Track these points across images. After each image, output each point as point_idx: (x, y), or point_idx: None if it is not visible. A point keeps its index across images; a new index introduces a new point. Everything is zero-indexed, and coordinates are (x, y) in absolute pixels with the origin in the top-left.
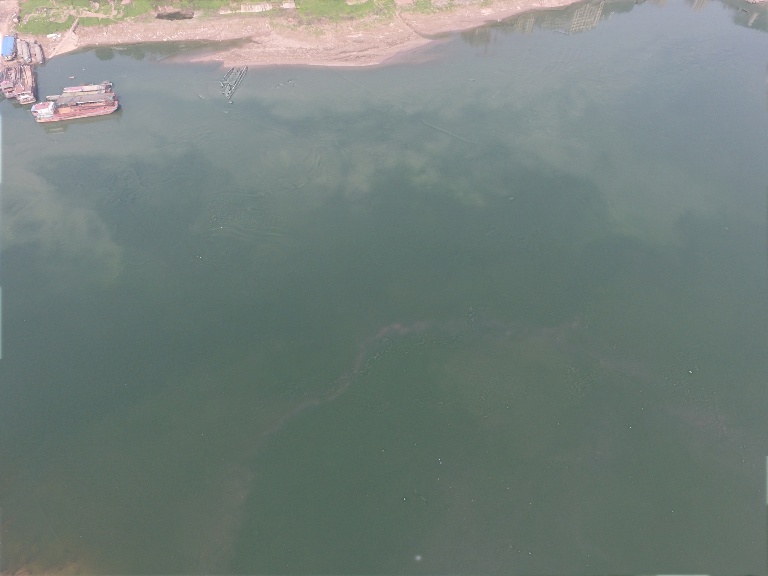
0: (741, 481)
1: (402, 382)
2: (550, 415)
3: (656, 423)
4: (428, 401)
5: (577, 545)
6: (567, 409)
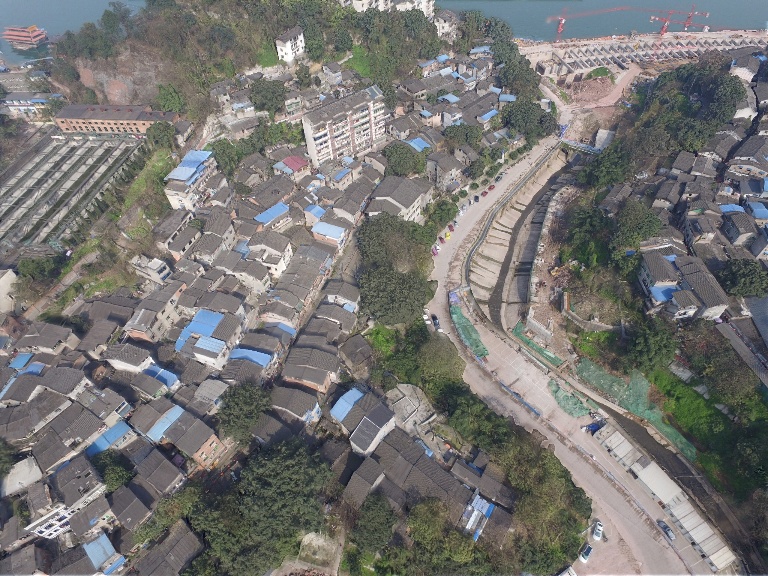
0: (587, 7)
1: (468, 0)
2: (522, 3)
3: (560, 1)
4: (478, 2)
5: (530, 16)
6: (528, 1)
